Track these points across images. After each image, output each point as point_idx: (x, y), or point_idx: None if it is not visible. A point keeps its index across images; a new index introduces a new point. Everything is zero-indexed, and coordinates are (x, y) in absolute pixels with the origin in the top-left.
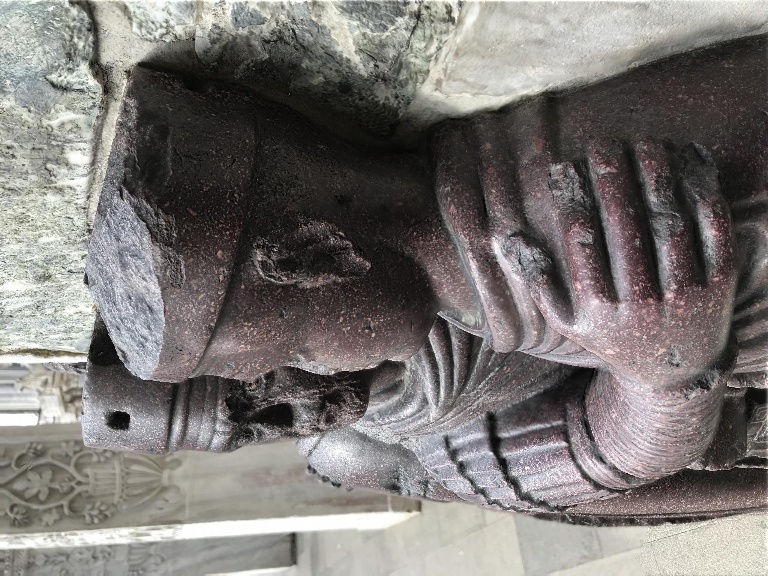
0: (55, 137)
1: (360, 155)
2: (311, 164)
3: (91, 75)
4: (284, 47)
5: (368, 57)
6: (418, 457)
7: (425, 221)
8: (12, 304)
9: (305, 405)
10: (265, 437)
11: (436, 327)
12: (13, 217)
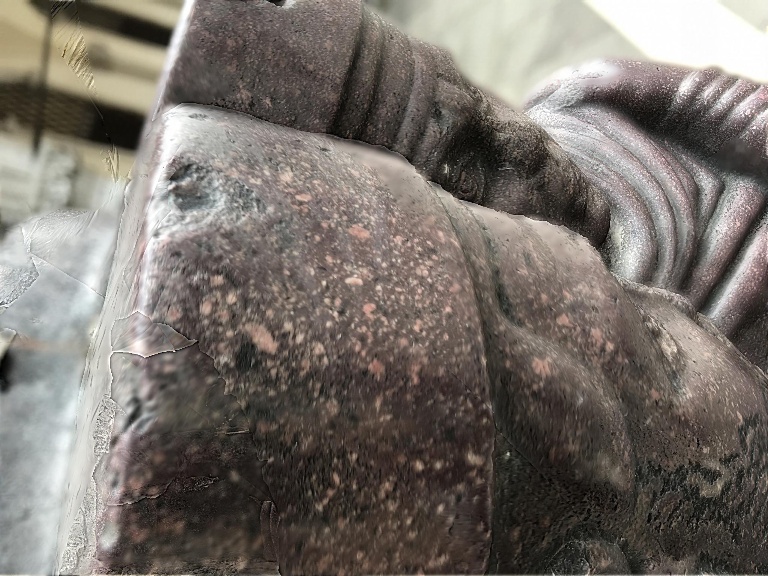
0: None
1: (221, 532)
2: (187, 518)
3: (78, 550)
4: (163, 572)
5: (201, 572)
6: None
7: (255, 500)
8: None
9: None
10: None
11: None
12: None
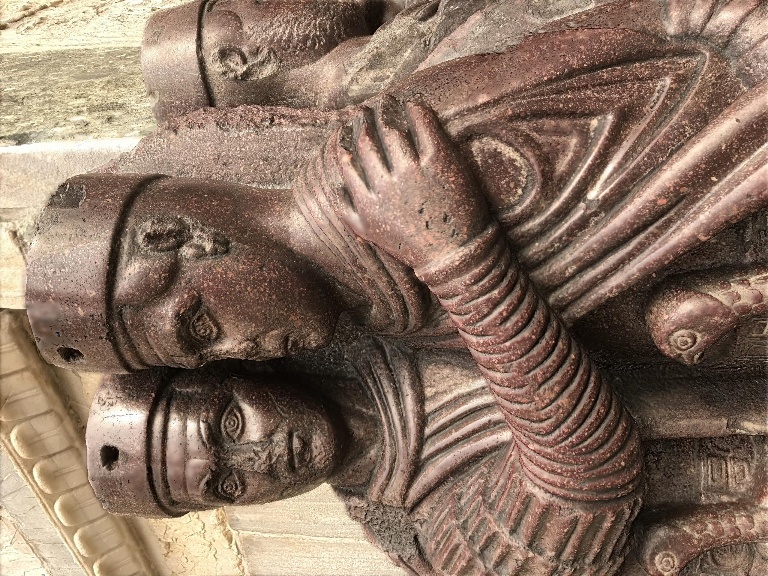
0: None
1: None
2: None
3: None
4: None
5: None
6: (440, 8)
7: None
8: None
9: None
10: None
11: None
12: None
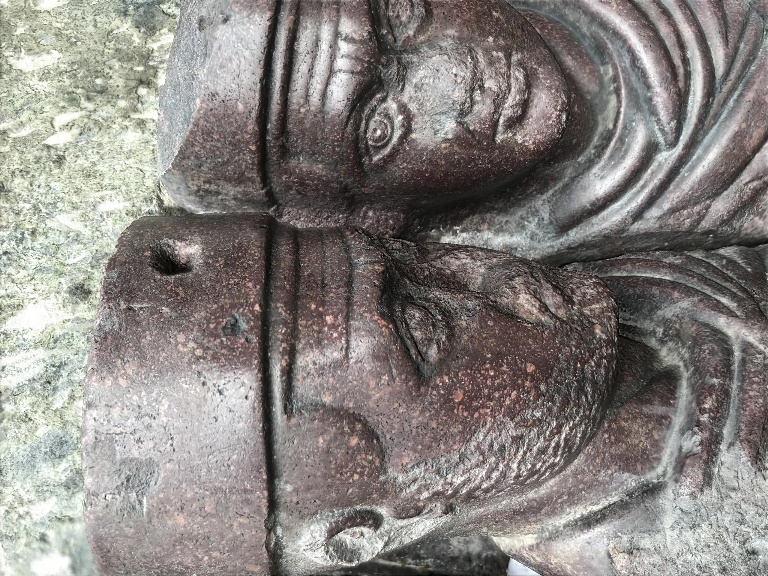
0: (153, 57)
1: None
2: None
3: None
4: None
5: None
6: None
7: None
8: (8, 377)
9: (496, 266)
10: (458, 329)
11: (630, 260)
12: (81, 170)
